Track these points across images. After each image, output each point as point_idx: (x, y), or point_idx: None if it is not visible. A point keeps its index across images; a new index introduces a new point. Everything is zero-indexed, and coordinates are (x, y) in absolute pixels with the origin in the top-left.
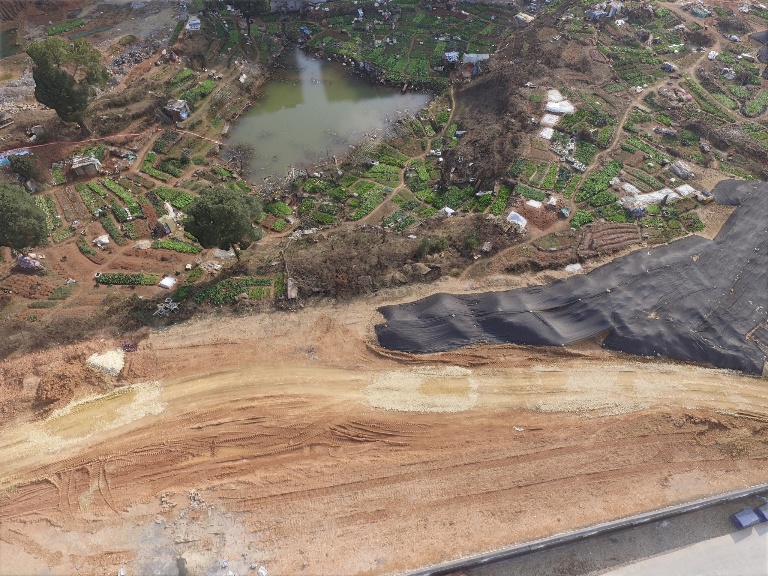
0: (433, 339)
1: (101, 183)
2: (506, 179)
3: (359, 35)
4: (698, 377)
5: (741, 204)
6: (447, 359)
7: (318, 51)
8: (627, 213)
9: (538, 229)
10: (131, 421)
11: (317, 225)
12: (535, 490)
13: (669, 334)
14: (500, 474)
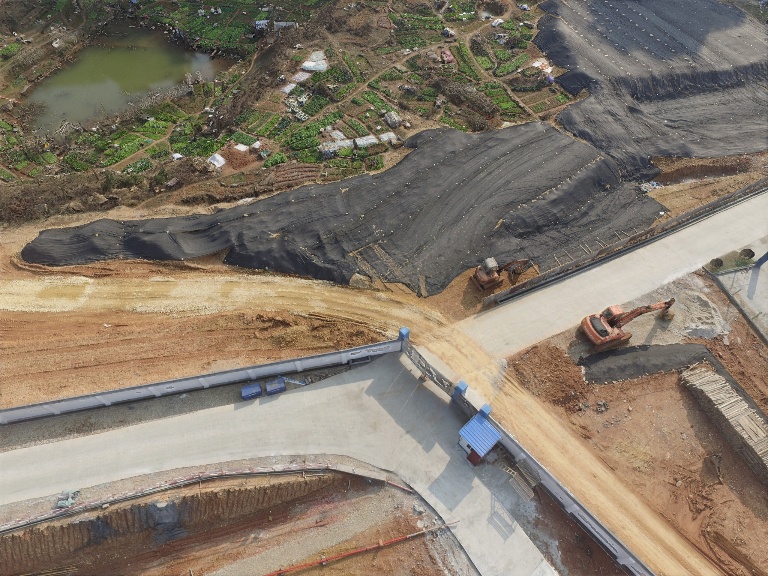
0: (72, 255)
1: None
2: (231, 127)
3: (188, 5)
4: (293, 286)
5: (418, 146)
6: (76, 271)
7: (143, 20)
8: (319, 155)
9: (232, 168)
10: None
11: (70, 172)
12: (88, 371)
13: (279, 250)
14: (64, 358)
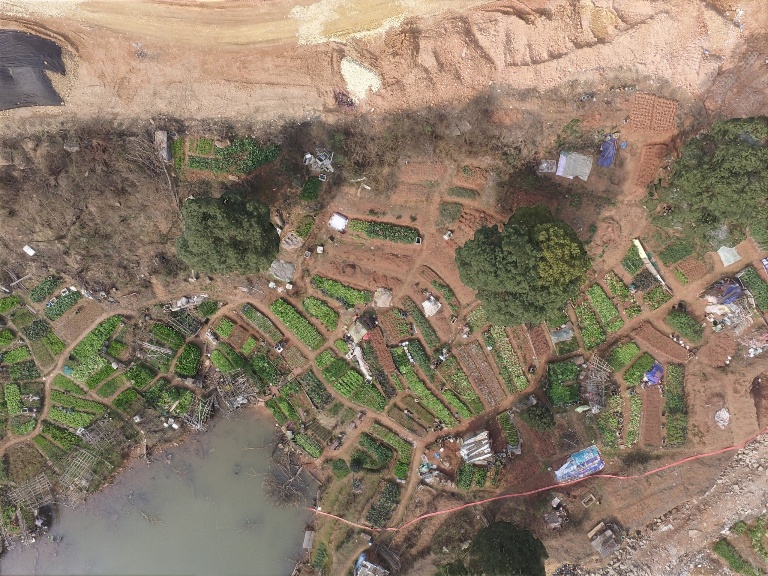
0: None
1: (454, 416)
2: None
3: None
4: None
5: None
6: None
7: None
8: None
9: None
10: (321, 2)
11: None
12: None
13: None
14: None
